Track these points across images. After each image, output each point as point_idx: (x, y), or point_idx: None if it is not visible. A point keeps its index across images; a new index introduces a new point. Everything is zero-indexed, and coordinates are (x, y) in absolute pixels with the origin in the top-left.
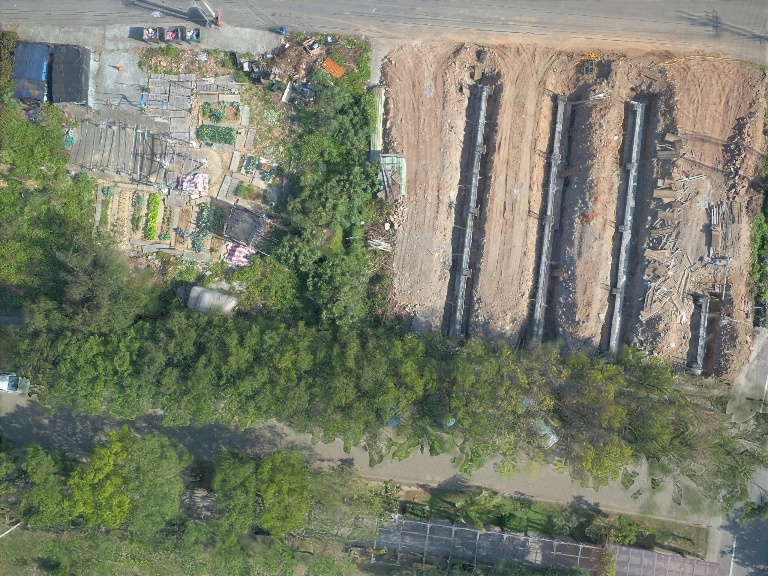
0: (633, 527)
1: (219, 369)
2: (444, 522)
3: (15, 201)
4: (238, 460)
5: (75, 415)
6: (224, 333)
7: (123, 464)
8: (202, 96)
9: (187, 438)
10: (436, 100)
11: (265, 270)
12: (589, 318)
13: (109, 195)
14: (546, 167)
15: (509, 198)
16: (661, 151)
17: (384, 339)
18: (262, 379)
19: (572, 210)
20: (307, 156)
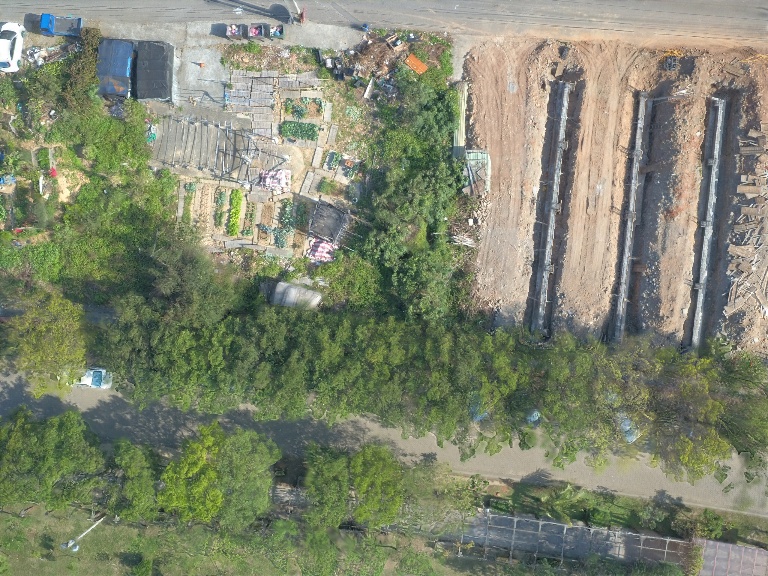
0: (719, 521)
1: (311, 364)
2: (527, 516)
3: (98, 197)
4: (328, 454)
5: (157, 410)
6: (315, 328)
7: (215, 458)
8: (284, 92)
9: (270, 433)
10: (519, 96)
11: (348, 266)
12: (673, 313)
13: (191, 191)
14: (627, 163)
15: (592, 194)
16: (744, 147)
17: (473, 334)
18: (356, 374)
19: (655, 206)
20: (390, 152)
